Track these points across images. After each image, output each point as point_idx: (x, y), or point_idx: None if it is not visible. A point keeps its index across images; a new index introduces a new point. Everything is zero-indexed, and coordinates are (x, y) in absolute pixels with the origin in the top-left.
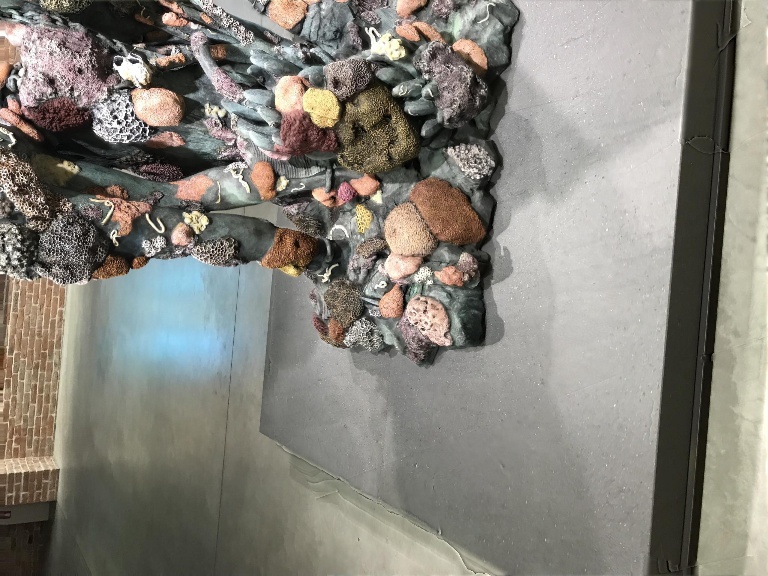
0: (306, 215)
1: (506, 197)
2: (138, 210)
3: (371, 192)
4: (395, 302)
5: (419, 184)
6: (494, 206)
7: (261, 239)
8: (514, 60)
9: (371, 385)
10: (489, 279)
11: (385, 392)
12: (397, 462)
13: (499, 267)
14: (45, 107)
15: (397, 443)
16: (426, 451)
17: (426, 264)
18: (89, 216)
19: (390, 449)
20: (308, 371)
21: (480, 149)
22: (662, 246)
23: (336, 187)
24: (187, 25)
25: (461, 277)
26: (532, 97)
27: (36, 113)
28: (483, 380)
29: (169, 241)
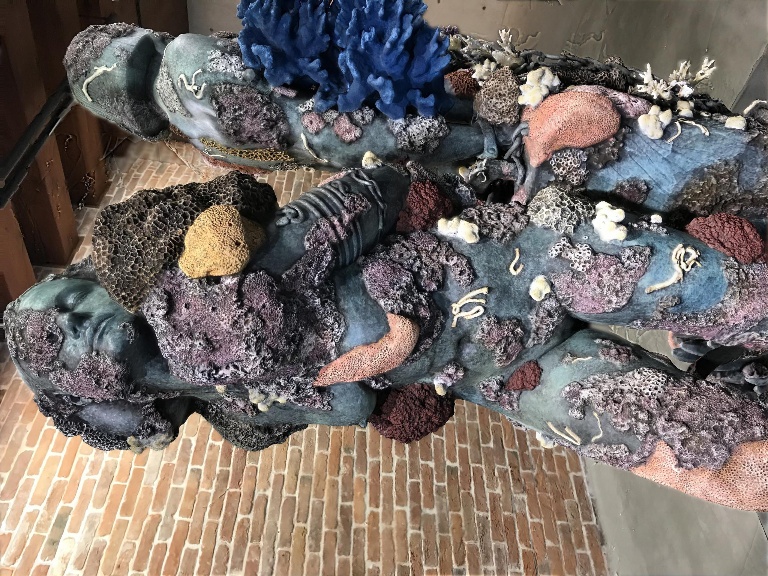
0: None
1: None
2: None
3: None
4: None
5: None
6: None
7: None
8: None
9: None
10: None
11: None
12: None
13: None
14: None
15: None
16: None
17: None
18: None
19: None
20: None
21: None
22: None
23: None
24: None
25: None
26: None
27: None
28: None
29: None
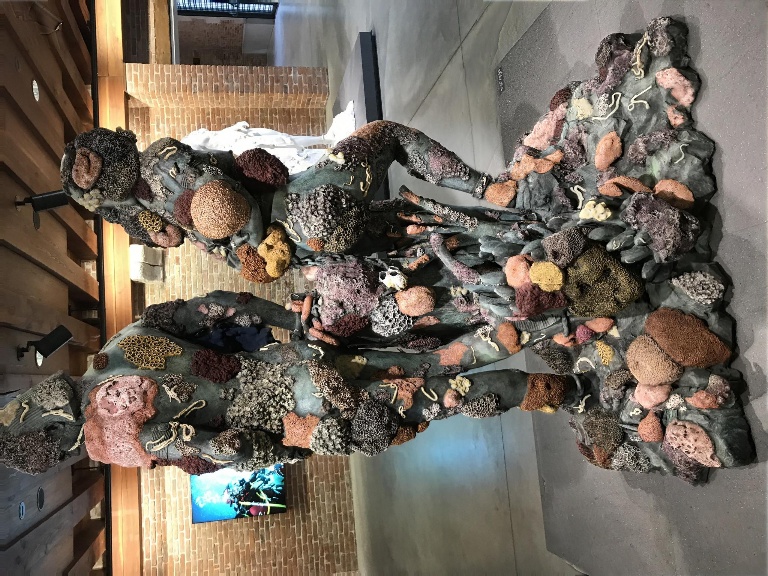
0: (551, 349)
1: (744, 314)
2: (415, 386)
3: (607, 329)
4: (653, 428)
5: (651, 316)
6: (733, 324)
7: (516, 389)
8: (720, 186)
9: (649, 503)
10: (746, 395)
11: (664, 511)
12: None
13: (754, 383)
14: (339, 323)
15: (689, 563)
16: (721, 572)
17: (675, 391)
18: (381, 399)
19: (683, 570)
20: (583, 489)
21: (705, 275)
22: None
23: (573, 330)
24: (426, 230)
25: (714, 400)
26: (747, 219)
27: (333, 328)
28: (765, 498)
29: (442, 406)
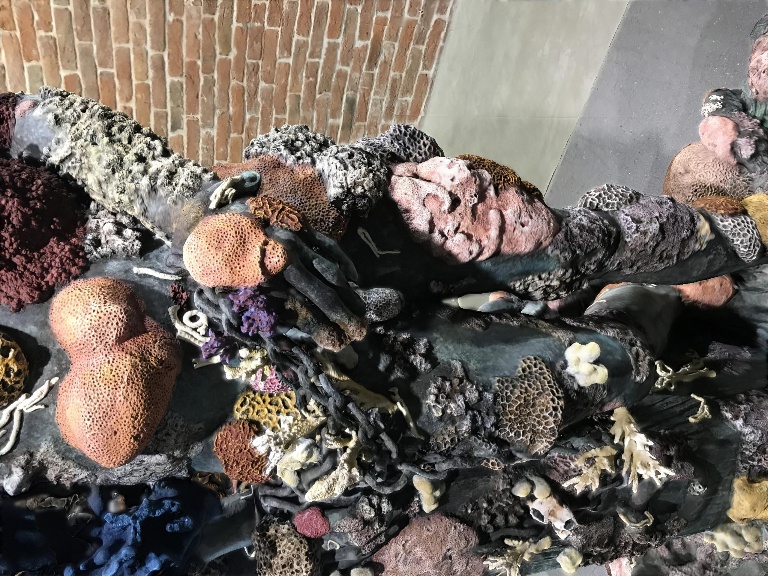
0: None
1: None
2: None
3: None
4: None
5: None
6: None
7: None
8: None
9: None
10: None
11: None
12: None
13: None
14: None
15: None
16: None
17: None
18: None
19: None
20: None
21: None
22: (614, 49)
23: None
24: None
25: None
26: None
27: None
28: None
29: None
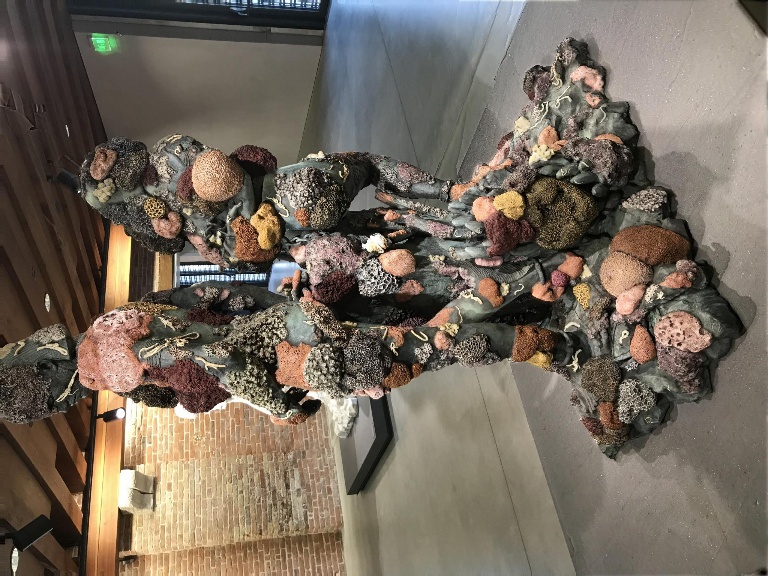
0: None
1: (690, 211)
2: (405, 329)
3: (579, 270)
4: (642, 338)
5: (613, 239)
6: (685, 224)
7: (505, 333)
8: (641, 129)
9: (671, 465)
10: (715, 277)
11: (687, 459)
12: (737, 518)
13: (717, 261)
14: (327, 281)
15: (726, 498)
16: (757, 479)
17: None
18: (372, 336)
19: (723, 511)
20: (608, 512)
21: (648, 190)
22: None
23: (549, 278)
24: (401, 217)
25: (685, 277)
26: (667, 136)
27: (322, 289)
28: (764, 360)
29: (434, 347)
